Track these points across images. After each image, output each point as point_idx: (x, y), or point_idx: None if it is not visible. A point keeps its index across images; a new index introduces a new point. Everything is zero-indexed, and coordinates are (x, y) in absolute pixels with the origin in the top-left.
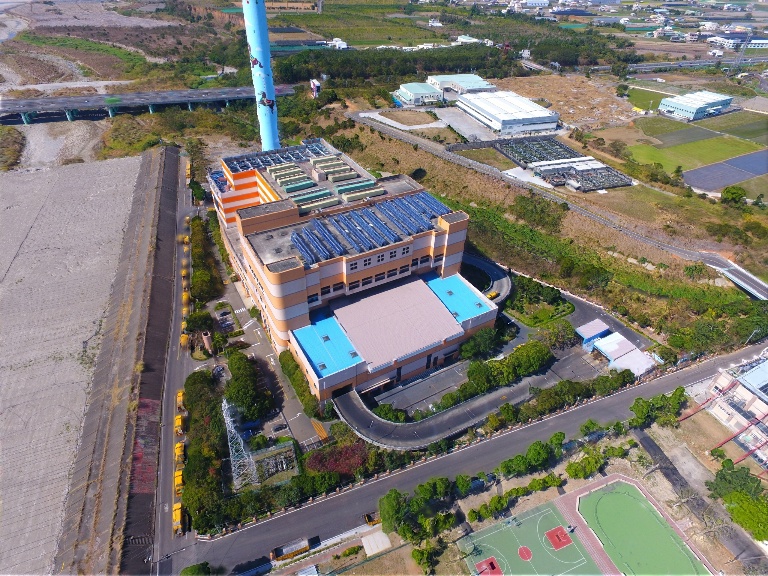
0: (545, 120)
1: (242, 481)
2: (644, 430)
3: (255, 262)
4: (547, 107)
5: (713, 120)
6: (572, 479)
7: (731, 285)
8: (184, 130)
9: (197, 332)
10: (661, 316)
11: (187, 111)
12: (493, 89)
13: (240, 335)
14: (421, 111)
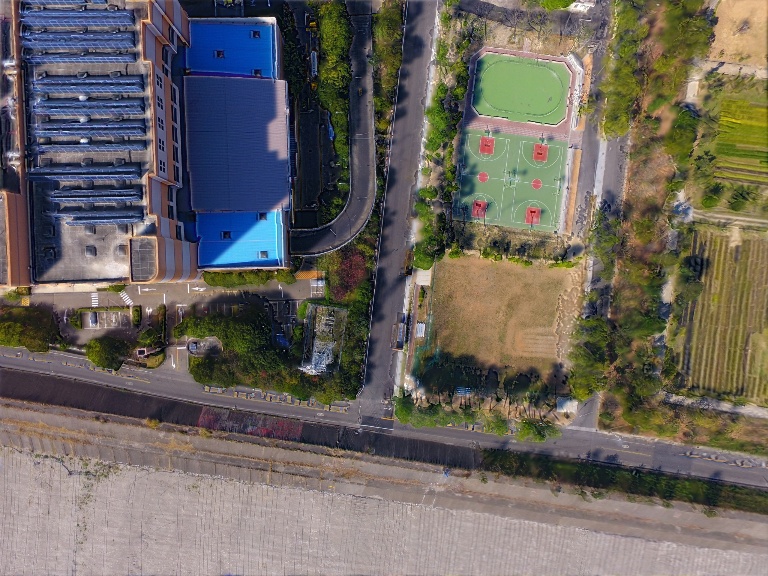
0: None
1: (330, 356)
2: None
3: None
4: None
5: None
6: None
7: None
8: None
9: (125, 359)
10: None
11: None
12: None
13: (141, 311)
14: None
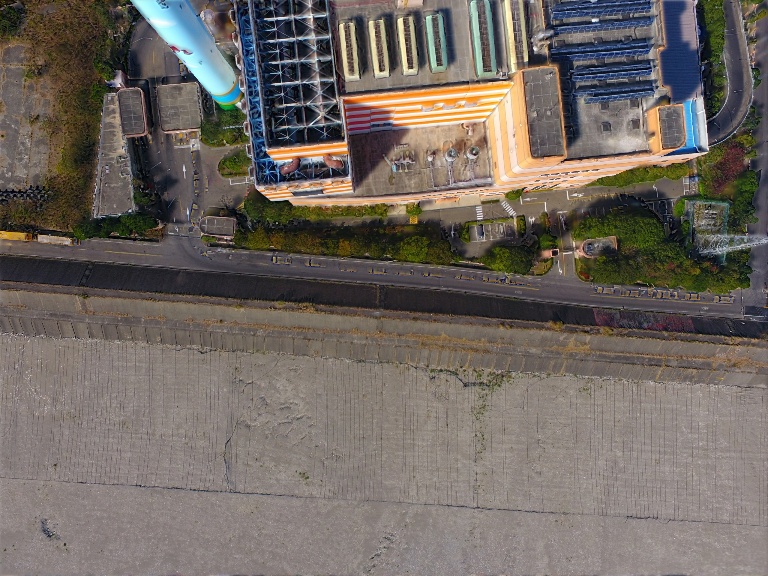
0: None
1: None
2: None
3: None
4: None
5: None
6: None
7: None
8: None
9: None
10: None
11: None
12: None
13: (525, 220)
14: None
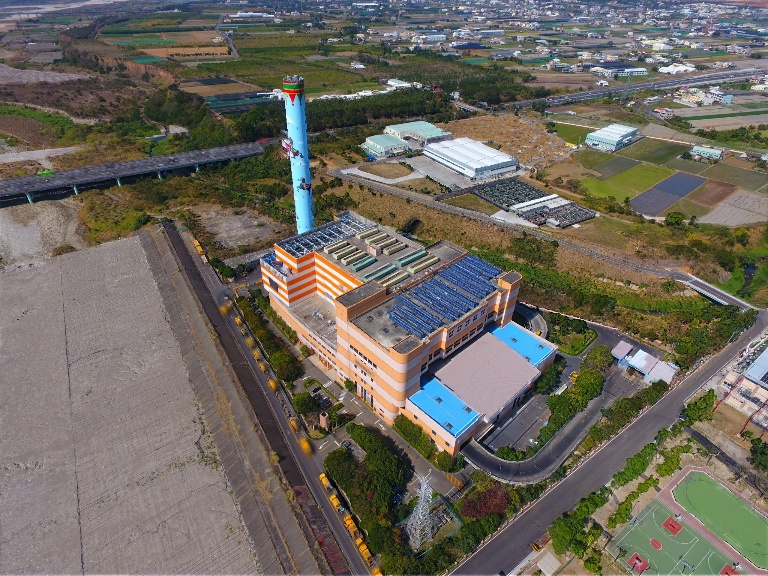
0: (508, 164)
1: (421, 541)
2: (691, 427)
3: (369, 344)
4: (499, 149)
5: (629, 149)
6: (661, 478)
7: (696, 294)
8: (167, 202)
9: (309, 413)
10: (662, 330)
11: (157, 180)
12: (449, 136)
13: (341, 408)
14: (394, 163)
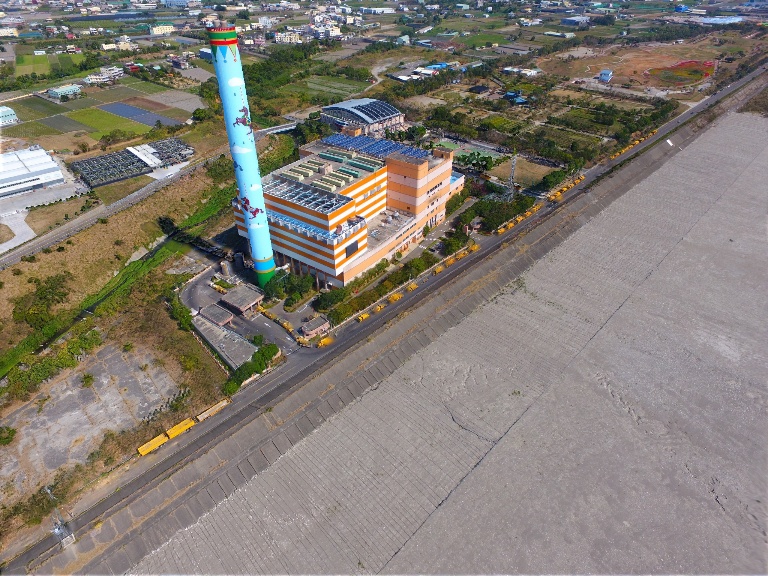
0: None
1: None
2: None
3: None
4: None
5: None
6: None
7: (276, 135)
8: None
9: None
10: None
11: None
12: None
13: None
14: None
